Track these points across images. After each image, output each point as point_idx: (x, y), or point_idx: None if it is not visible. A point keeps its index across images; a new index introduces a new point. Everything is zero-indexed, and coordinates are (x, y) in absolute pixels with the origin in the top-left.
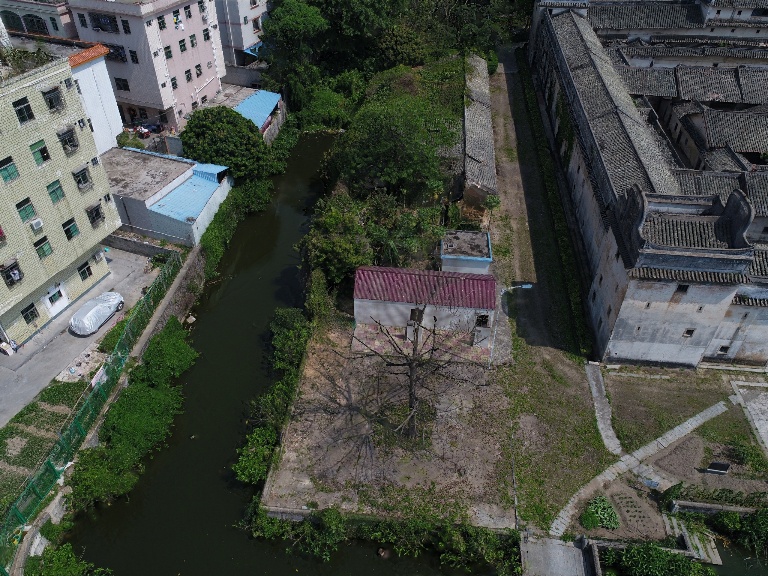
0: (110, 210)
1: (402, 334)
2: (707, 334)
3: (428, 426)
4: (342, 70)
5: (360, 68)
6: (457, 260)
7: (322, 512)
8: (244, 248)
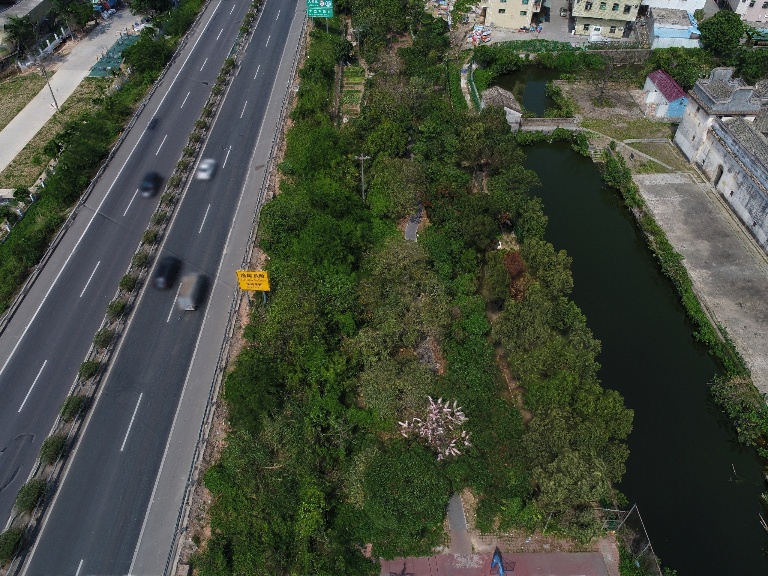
0: (634, 12)
1: None
2: None
3: None
4: None
5: None
6: None
7: None
8: None
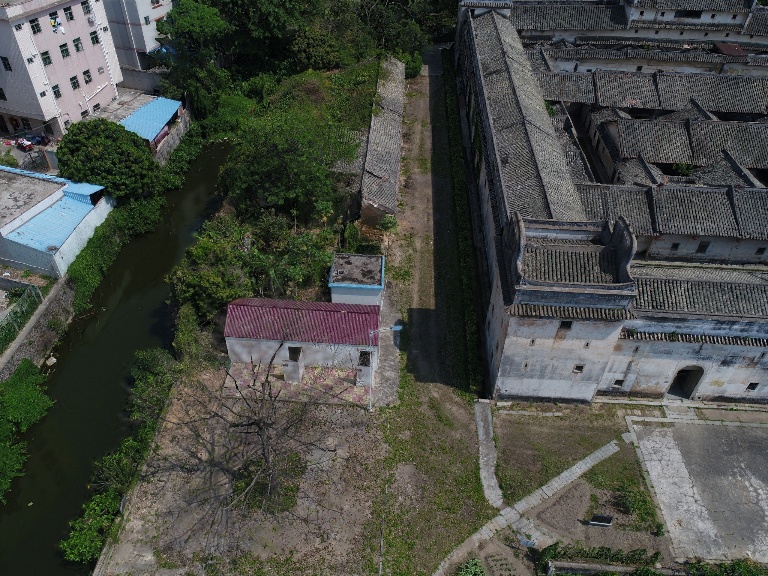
0: None
1: (281, 373)
2: (597, 370)
3: (295, 482)
4: (256, 73)
5: (276, 71)
6: (346, 288)
7: None
8: (134, 271)
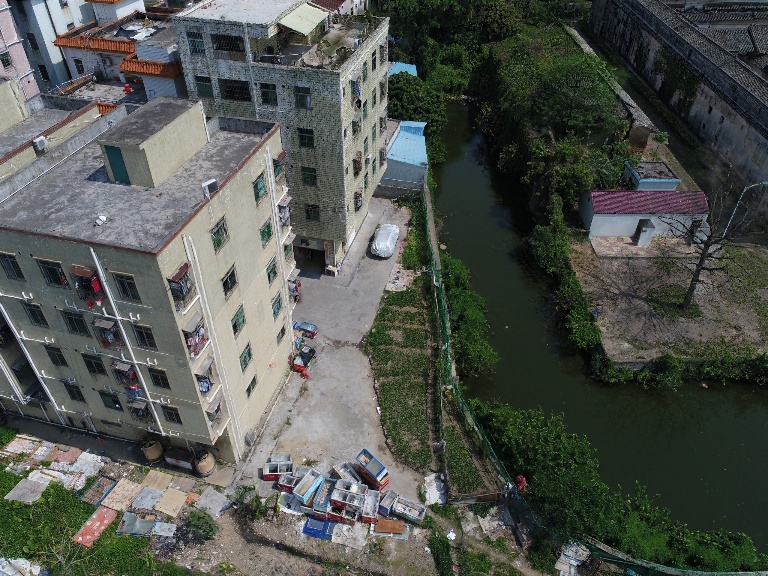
0: None
1: (630, 242)
2: None
3: (692, 301)
4: (441, 45)
5: None
6: (652, 183)
7: (663, 357)
8: None
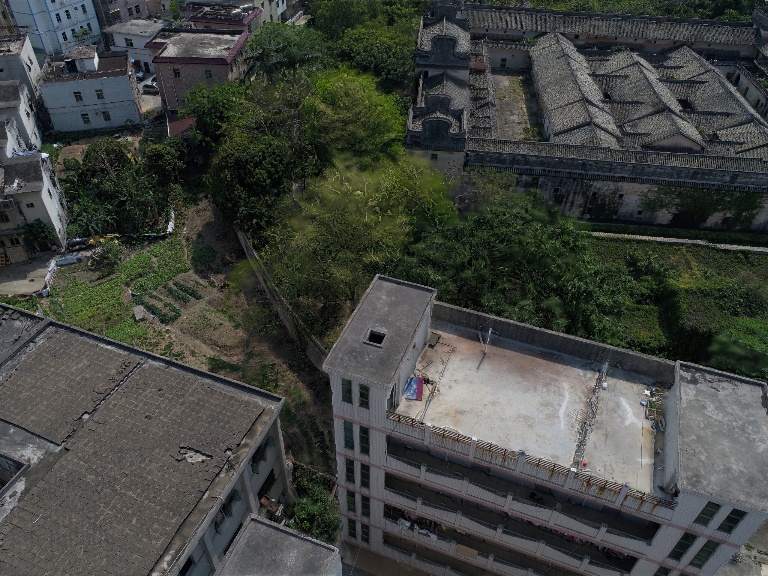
0: None
1: None
2: None
3: None
4: None
5: None
6: None
7: None
8: None
